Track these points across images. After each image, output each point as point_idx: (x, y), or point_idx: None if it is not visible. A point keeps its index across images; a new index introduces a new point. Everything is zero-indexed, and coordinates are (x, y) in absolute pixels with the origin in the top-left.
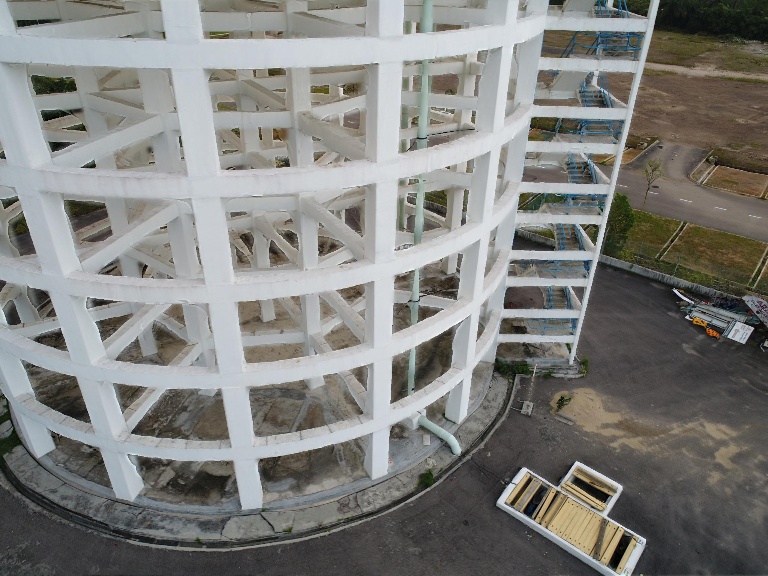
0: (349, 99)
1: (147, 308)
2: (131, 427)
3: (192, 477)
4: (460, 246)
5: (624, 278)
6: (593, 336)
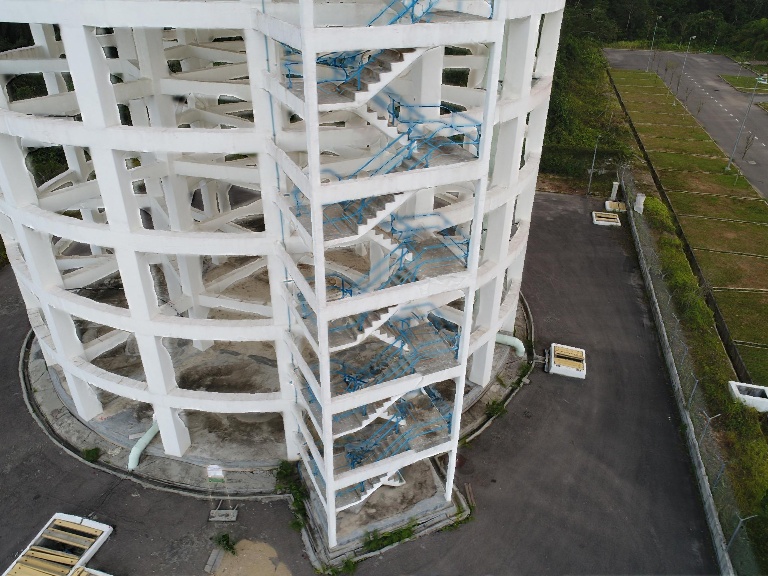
0: (213, 83)
1: (97, 197)
2: (63, 266)
3: (81, 327)
4: (79, 237)
5: None
6: (440, 575)
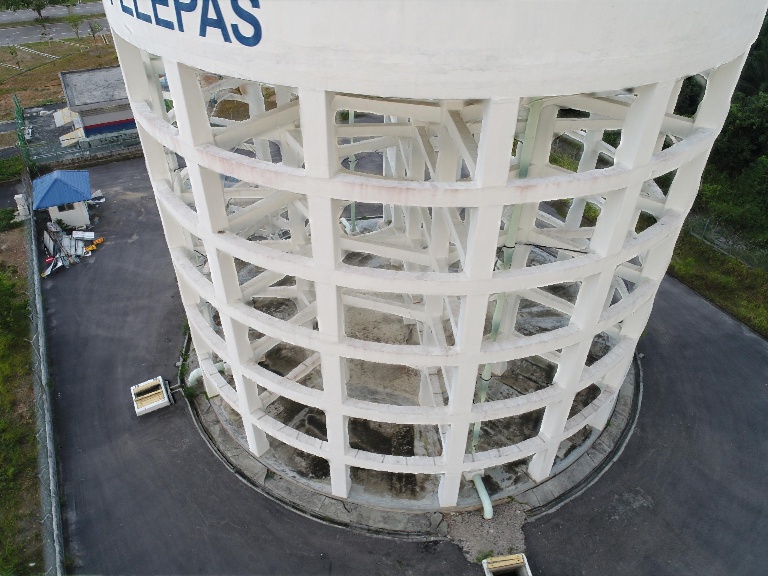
0: None
1: None
2: None
3: None
4: None
5: (58, 298)
6: None
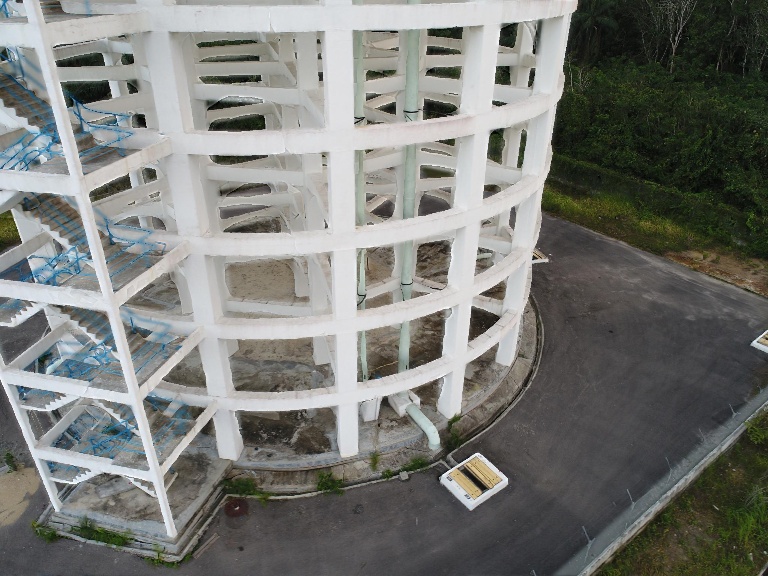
0: None
1: None
2: None
3: None
4: None
5: None
6: None
